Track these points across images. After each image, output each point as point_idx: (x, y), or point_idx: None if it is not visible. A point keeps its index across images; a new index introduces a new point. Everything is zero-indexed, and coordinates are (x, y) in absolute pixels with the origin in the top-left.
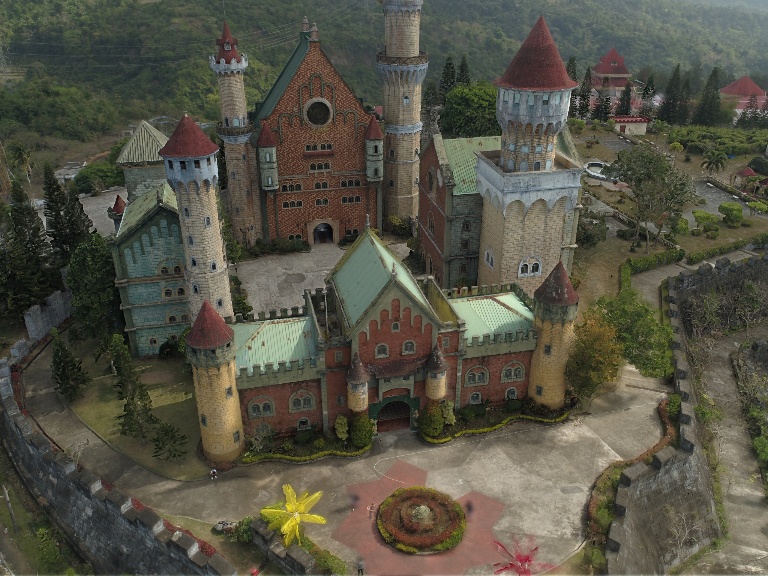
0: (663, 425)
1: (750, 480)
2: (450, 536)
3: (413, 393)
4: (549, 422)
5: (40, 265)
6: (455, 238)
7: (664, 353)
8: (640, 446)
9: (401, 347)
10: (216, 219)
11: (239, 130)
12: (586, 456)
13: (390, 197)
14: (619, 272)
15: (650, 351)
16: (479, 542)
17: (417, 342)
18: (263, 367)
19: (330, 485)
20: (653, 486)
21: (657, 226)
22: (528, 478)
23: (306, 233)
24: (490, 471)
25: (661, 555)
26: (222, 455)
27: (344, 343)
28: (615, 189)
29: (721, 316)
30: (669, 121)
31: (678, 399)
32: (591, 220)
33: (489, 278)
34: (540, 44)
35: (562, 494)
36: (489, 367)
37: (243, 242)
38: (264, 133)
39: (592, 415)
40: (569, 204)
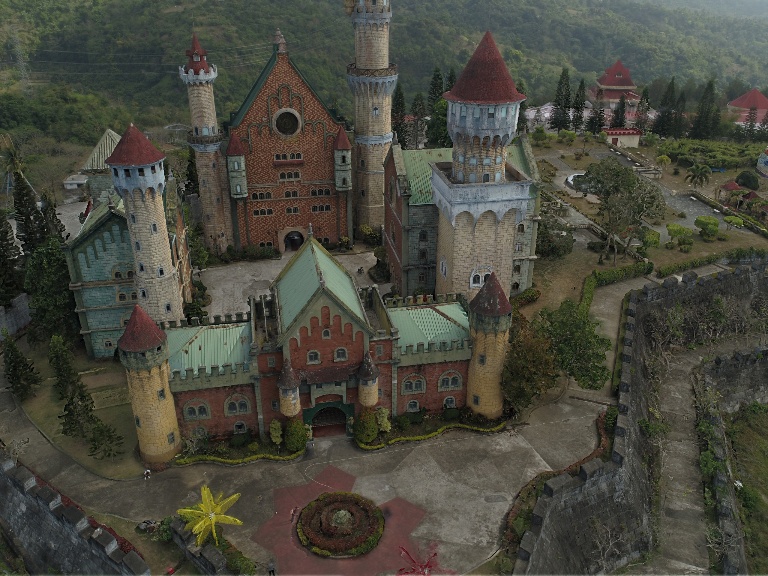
0: (599, 437)
1: (685, 494)
2: (366, 541)
3: (346, 399)
4: (485, 431)
5: (8, 268)
6: (412, 248)
7: (615, 366)
8: (572, 457)
9: (333, 354)
10: (163, 226)
11: (208, 139)
12: (516, 466)
13: (361, 206)
14: (583, 284)
15: (590, 363)
16: (394, 547)
17: (349, 349)
18: (197, 371)
19: (258, 488)
20: (579, 497)
21: (622, 239)
22: (454, 486)
23: (277, 241)
24: (418, 478)
25: (585, 566)
26: (156, 456)
27: (276, 349)
28: (596, 201)
29: (687, 330)
30: (664, 134)
31: (615, 411)
32: (558, 232)
33: (444, 288)
34: (486, 58)
35: (485, 503)
36: (426, 375)
37: (214, 248)
38: (232, 142)
39: (530, 425)
40: (519, 216)
